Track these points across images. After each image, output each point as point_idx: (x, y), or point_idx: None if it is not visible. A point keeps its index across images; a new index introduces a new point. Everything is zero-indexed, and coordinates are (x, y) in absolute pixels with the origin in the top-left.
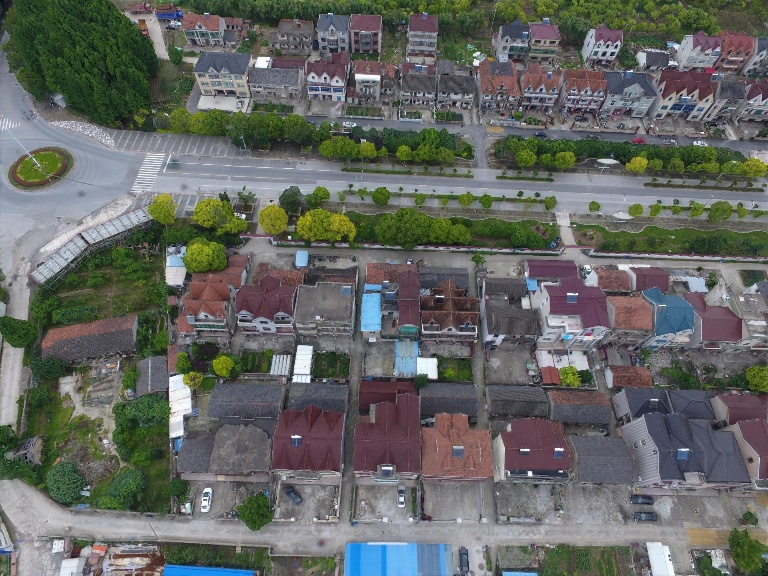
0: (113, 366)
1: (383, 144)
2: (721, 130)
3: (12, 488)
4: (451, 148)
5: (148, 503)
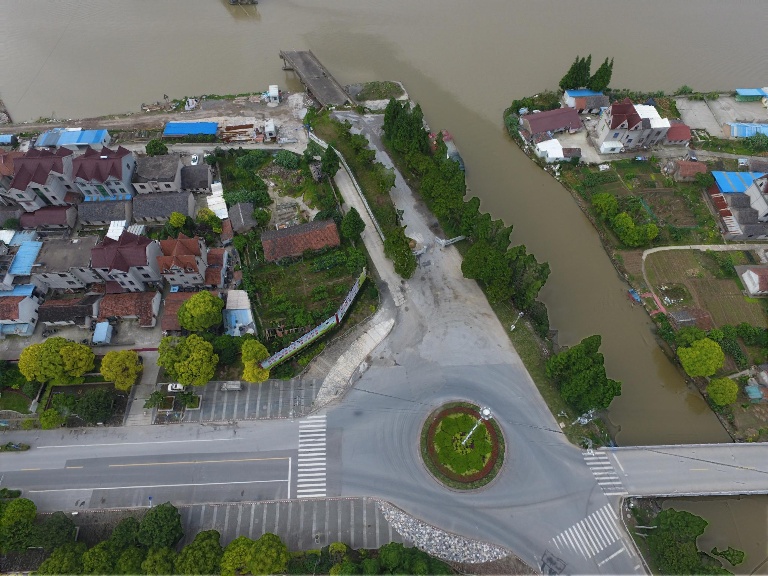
0: (281, 226)
1: None
2: None
3: None
4: None
5: (234, 158)
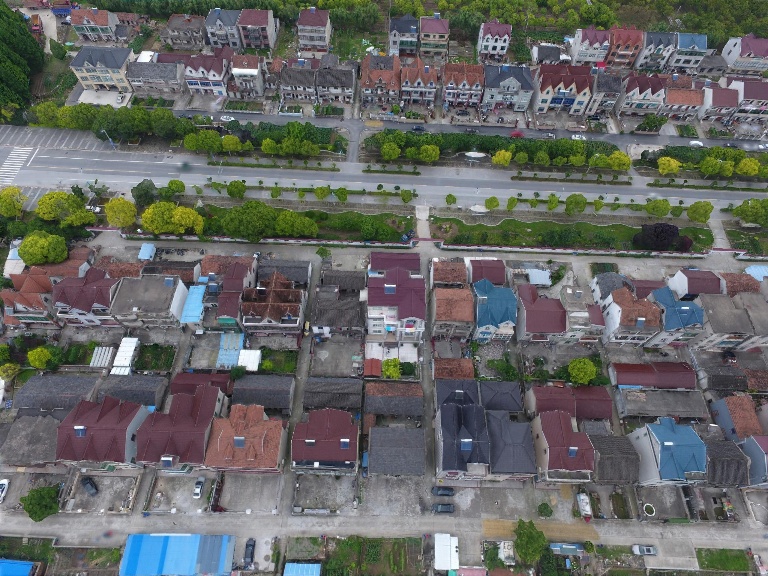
0: None
1: (251, 138)
2: (603, 124)
3: None
4: (324, 142)
5: None
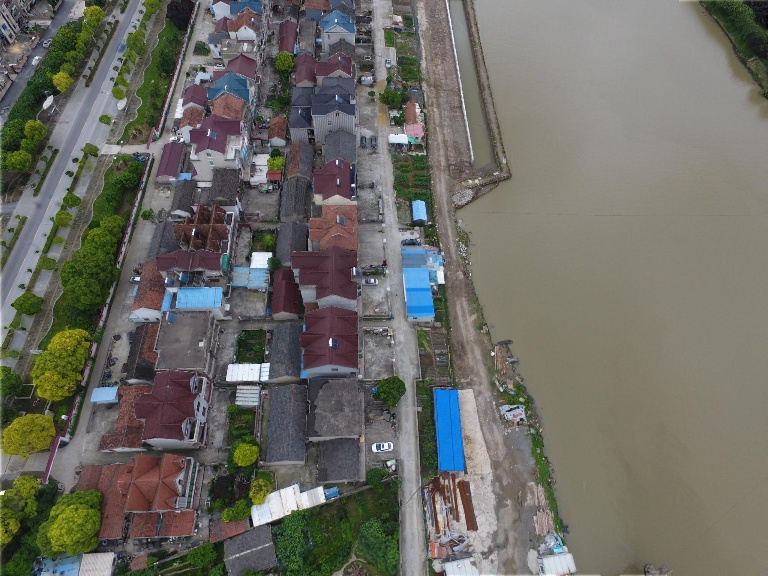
0: None
1: None
2: (35, 26)
3: None
4: None
5: None
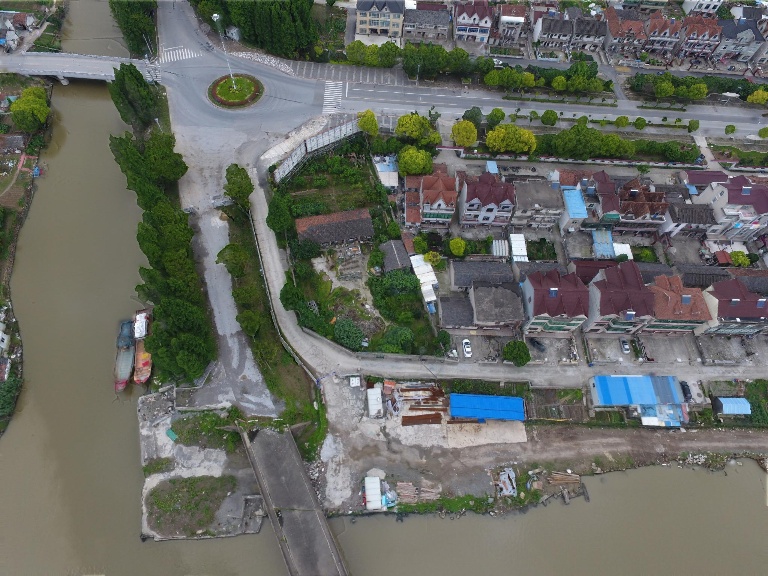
0: (356, 249)
1: None
2: None
3: (302, 340)
4: None
5: None
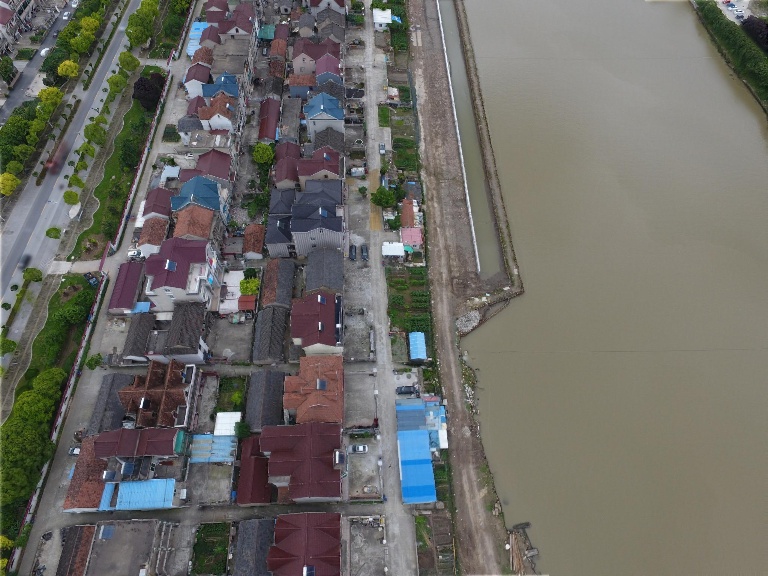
0: None
1: None
2: None
3: None
4: None
5: None
